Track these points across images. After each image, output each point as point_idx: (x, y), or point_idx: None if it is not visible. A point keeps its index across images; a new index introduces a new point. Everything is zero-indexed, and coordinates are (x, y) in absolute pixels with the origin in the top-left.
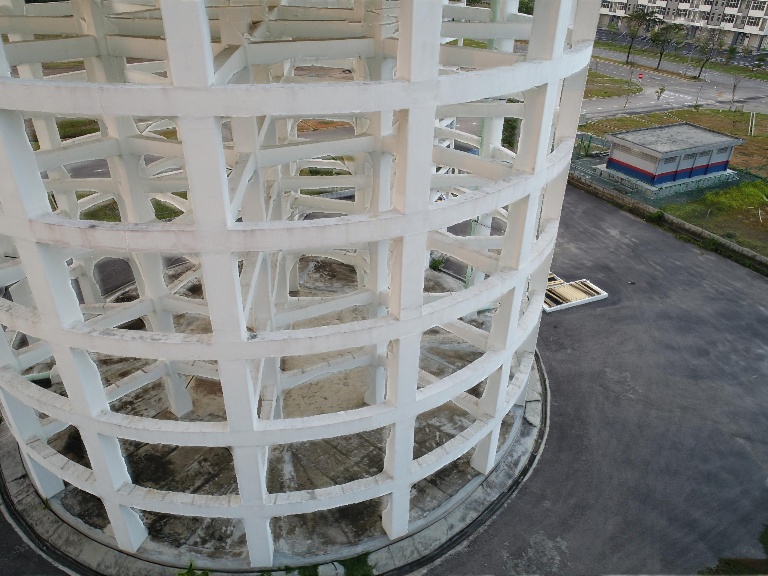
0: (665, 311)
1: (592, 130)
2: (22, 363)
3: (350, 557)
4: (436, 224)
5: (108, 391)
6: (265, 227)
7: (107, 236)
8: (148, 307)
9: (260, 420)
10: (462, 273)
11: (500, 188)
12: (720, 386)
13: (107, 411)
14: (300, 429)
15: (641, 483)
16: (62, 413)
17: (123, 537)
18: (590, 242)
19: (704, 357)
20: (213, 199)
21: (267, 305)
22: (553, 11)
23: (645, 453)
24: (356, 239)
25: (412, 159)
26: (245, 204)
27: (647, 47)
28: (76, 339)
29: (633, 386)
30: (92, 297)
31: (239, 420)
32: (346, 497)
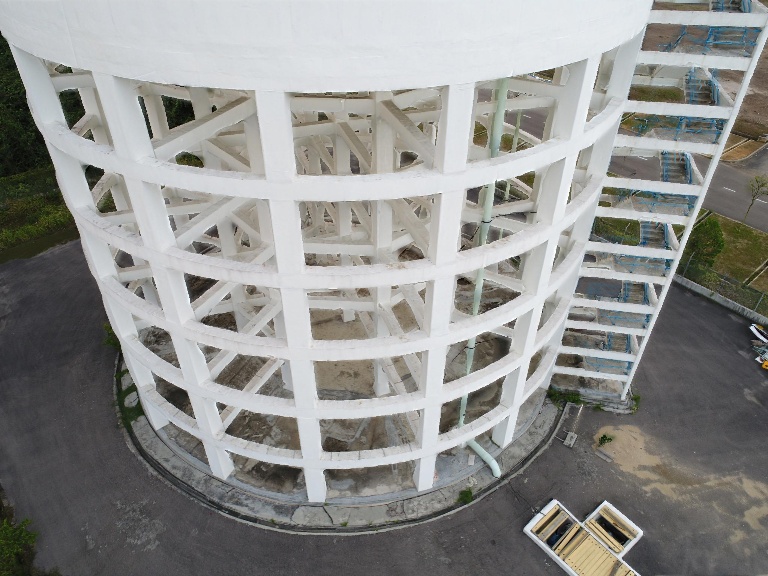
0: None
1: None
2: (178, 193)
3: None
4: None
5: None
6: None
7: None
8: None
9: None
10: (570, 428)
11: (114, 233)
12: None
13: (127, 228)
14: None
15: None
16: None
17: None
18: None
19: None
20: None
21: None
22: None
23: None
24: None
25: None
26: None
27: None
28: None
29: None
30: None
31: None
32: None
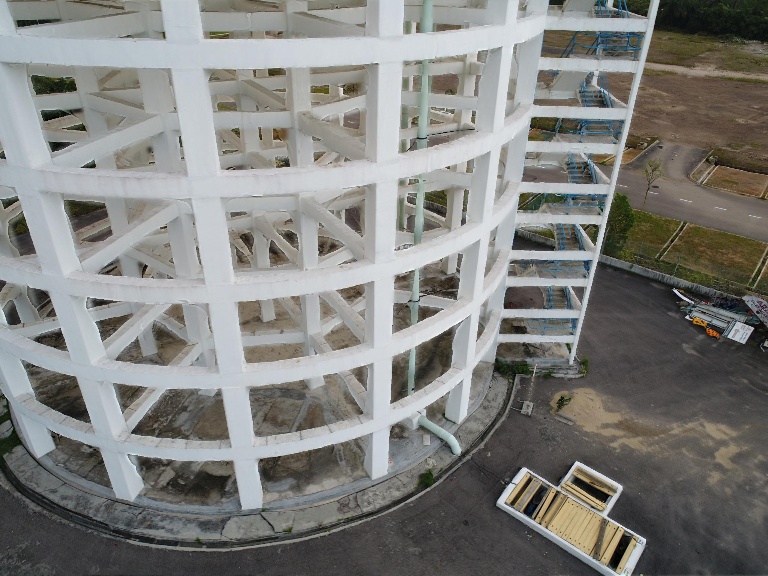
0: None
1: None
2: None
3: None
4: None
5: None
6: None
7: None
8: (135, 204)
9: None
10: (524, 397)
11: None
12: None
13: None
14: None
15: None
16: None
17: None
18: None
19: None
20: None
21: None
22: None
23: None
24: None
25: None
26: None
27: None
28: None
29: None
30: None
31: None
32: None
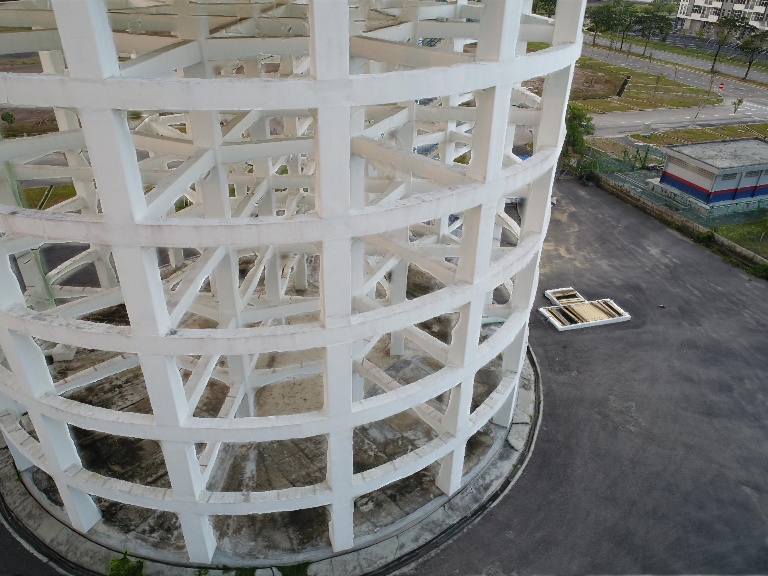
0: (692, 339)
1: (656, 141)
2: None
3: (290, 564)
4: (360, 230)
5: (85, 373)
6: (173, 223)
7: (25, 223)
8: None
9: (189, 417)
10: None
11: (440, 196)
12: (737, 427)
13: (51, 393)
14: (226, 430)
15: (620, 524)
16: (12, 391)
17: (74, 517)
18: (625, 260)
19: (726, 393)
20: (118, 192)
21: (232, 302)
22: (499, 9)
23: (633, 492)
24: (269, 241)
25: (326, 161)
26: (206, 199)
27: (735, 55)
28: (12, 321)
29: (636, 418)
30: (107, 281)
31: (164, 415)
32: (281, 503)
